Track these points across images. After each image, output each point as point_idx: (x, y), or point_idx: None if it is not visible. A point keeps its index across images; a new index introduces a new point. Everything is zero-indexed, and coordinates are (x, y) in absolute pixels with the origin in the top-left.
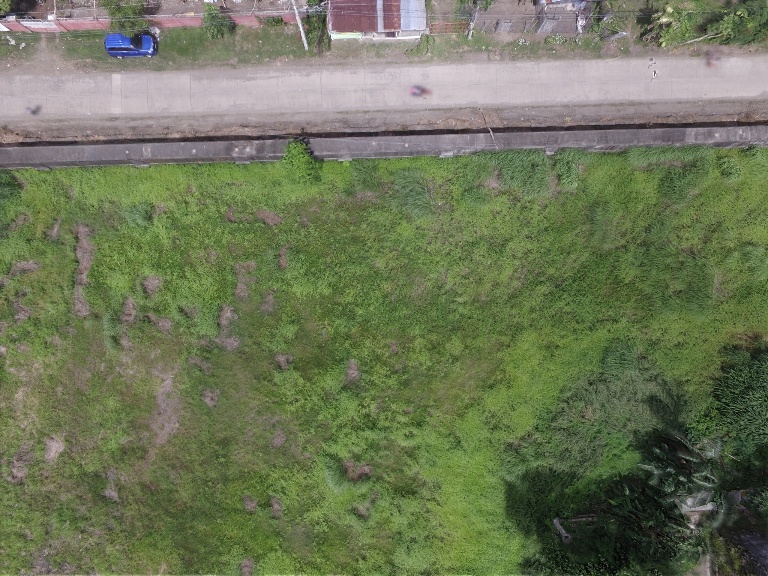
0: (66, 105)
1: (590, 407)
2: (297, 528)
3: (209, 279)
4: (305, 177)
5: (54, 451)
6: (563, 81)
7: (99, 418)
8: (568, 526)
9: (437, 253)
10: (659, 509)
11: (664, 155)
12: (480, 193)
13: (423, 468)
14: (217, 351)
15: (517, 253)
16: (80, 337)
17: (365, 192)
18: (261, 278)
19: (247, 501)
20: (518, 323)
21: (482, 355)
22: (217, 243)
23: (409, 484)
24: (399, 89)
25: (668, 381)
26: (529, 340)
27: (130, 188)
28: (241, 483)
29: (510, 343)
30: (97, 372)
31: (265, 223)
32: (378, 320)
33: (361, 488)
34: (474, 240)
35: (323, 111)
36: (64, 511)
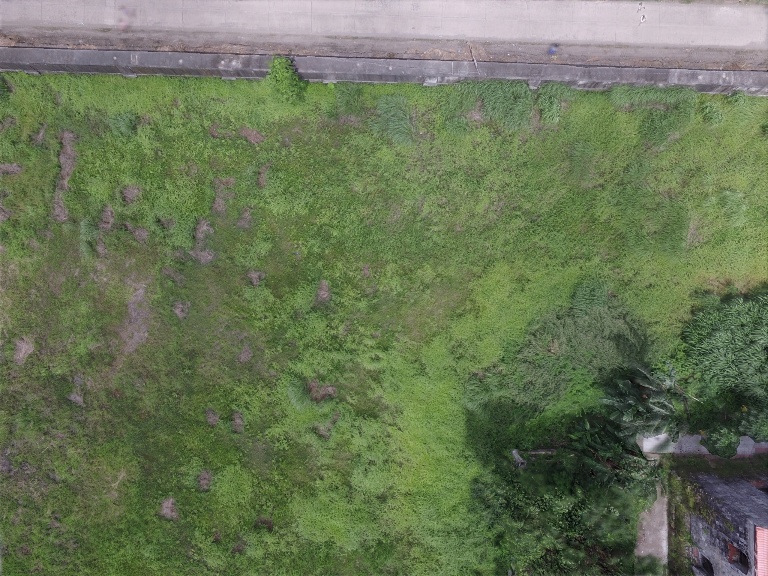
0: (60, 13)
1: (557, 341)
2: (258, 444)
3: (188, 191)
4: (288, 94)
5: (23, 352)
6: (551, 19)
7: (70, 322)
8: (527, 459)
9: (415, 180)
10: (618, 443)
11: (646, 96)
12: (461, 122)
13: (387, 392)
14: (191, 263)
15: (494, 185)
16: (57, 241)
17: (348, 116)
18: (239, 194)
19: (210, 414)
20: (491, 255)
21: (453, 285)
22: (198, 157)
23: (372, 408)
24: (388, 17)
25: (637, 321)
26: (501, 272)
27: (116, 97)
28: (205, 395)
29: (482, 274)
30: (71, 277)
31: (247, 140)
32: (352, 243)
33: (323, 407)
34: (452, 170)
35: (312, 35)
36: (29, 411)
